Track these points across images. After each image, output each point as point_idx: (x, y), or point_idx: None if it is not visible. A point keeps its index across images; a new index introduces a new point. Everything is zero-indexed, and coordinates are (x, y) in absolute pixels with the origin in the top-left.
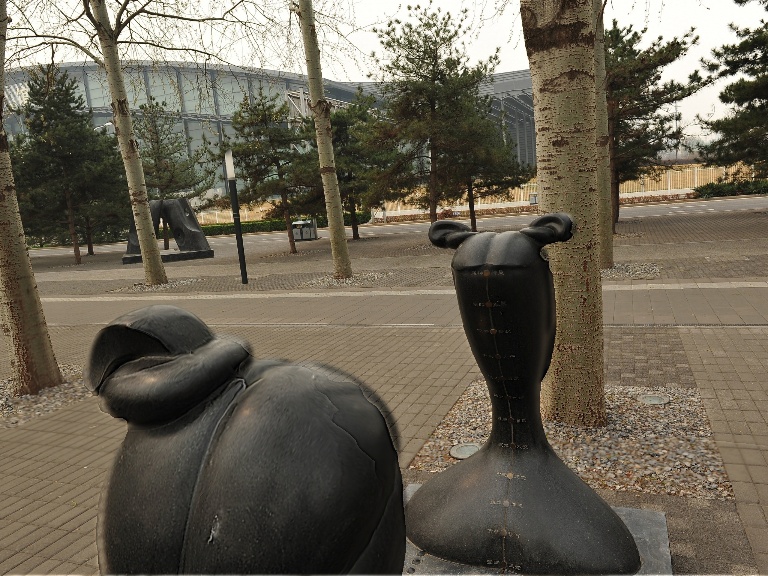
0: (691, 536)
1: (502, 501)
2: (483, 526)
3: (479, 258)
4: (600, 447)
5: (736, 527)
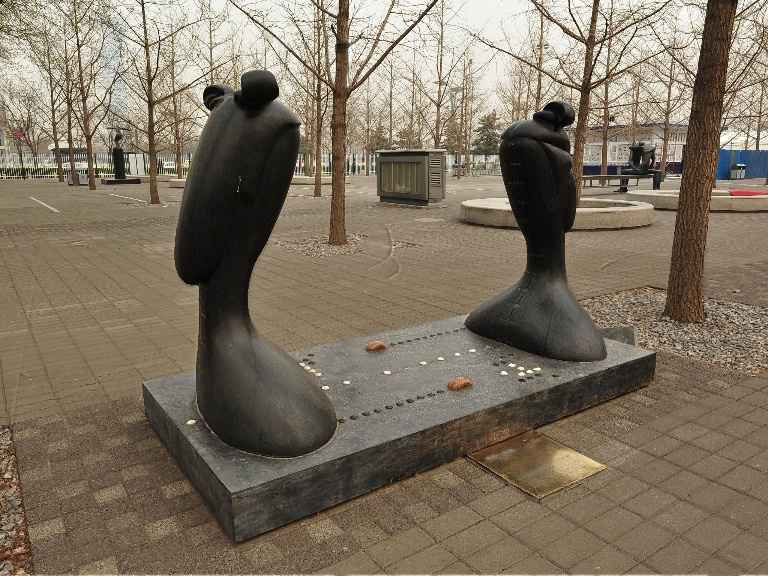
0: None
1: None
2: None
3: None
4: None
5: (72, 411)
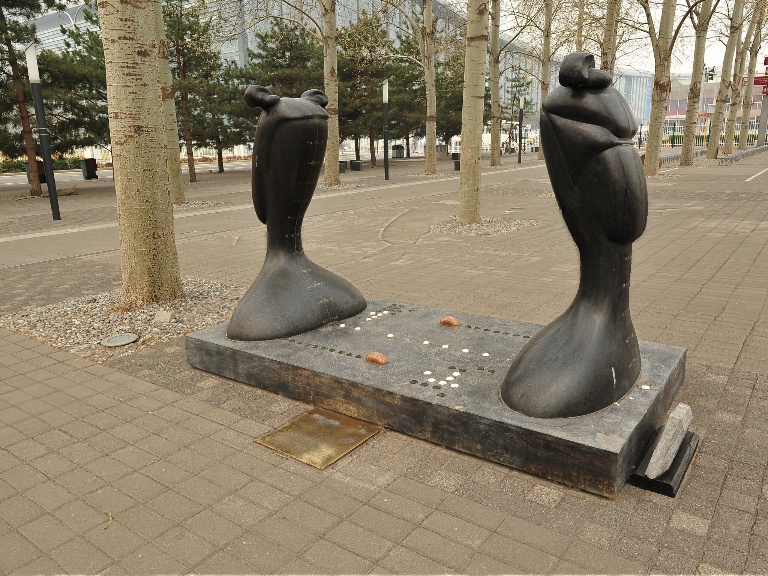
0: None
1: (313, 285)
2: (313, 302)
3: (309, 110)
4: (204, 305)
5: None
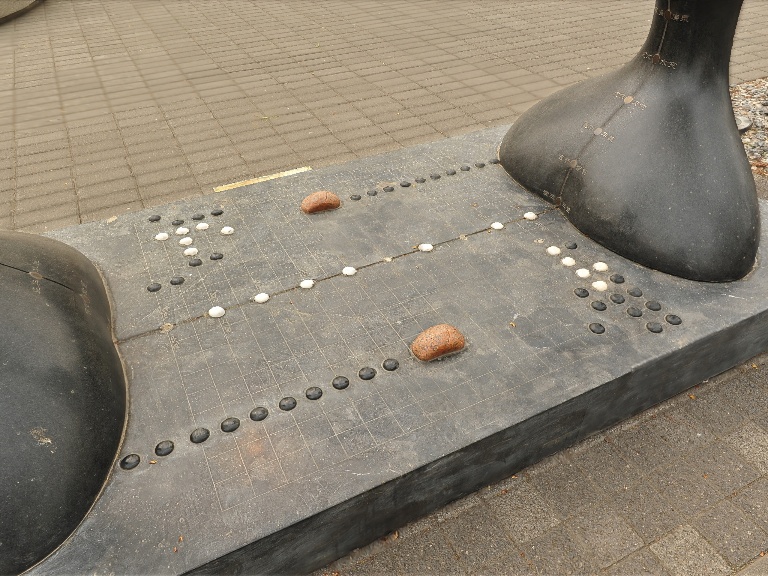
0: None
1: (595, 127)
2: (558, 149)
3: None
4: None
5: None
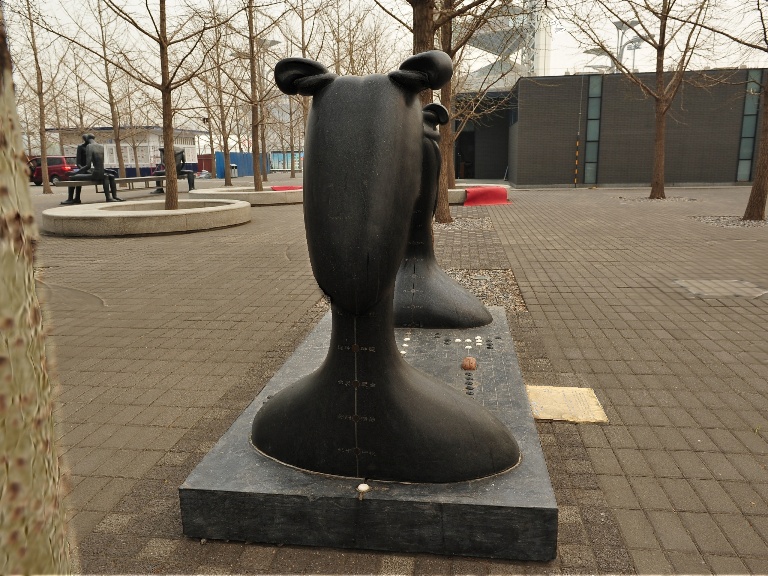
0: (124, 572)
1: None
2: None
3: None
4: None
5: None
